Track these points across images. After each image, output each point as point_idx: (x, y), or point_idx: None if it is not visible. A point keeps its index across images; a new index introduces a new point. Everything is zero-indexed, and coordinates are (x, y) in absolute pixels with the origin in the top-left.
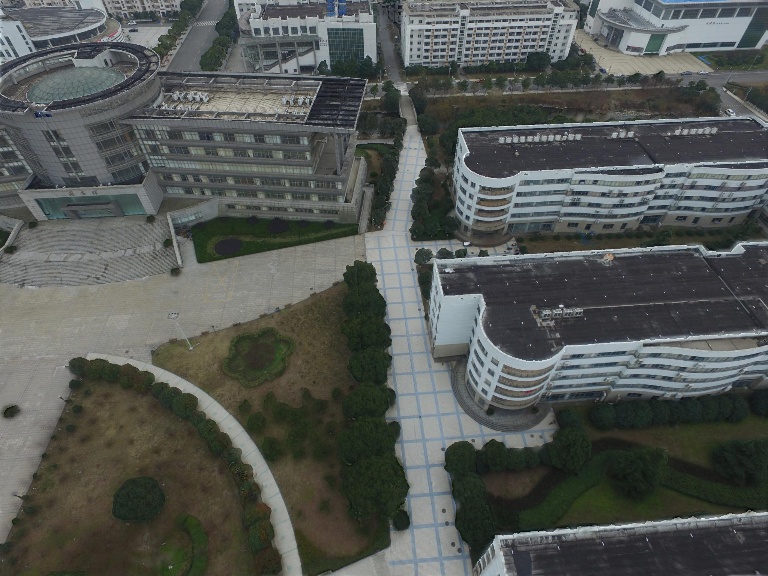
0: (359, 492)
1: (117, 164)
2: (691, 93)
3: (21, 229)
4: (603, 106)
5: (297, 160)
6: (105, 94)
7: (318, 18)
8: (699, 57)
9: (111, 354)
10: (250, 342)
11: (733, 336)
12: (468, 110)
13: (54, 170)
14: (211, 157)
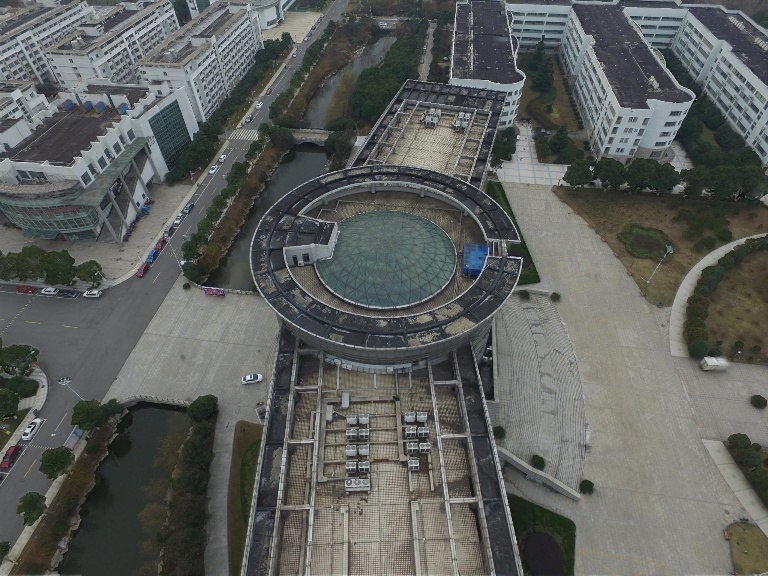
0: (766, 179)
1: None
2: (360, 24)
3: None
4: (350, 55)
5: None
6: (472, 196)
7: (127, 117)
8: (298, 11)
9: (669, 337)
10: None
11: None
12: (352, 95)
13: None
14: None
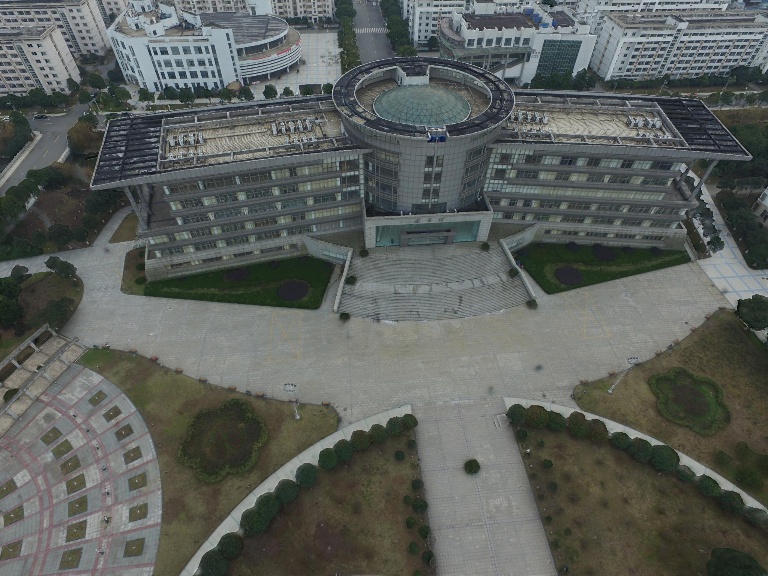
0: None
1: (468, 189)
2: None
3: (352, 257)
4: None
5: (656, 186)
6: (492, 117)
7: None
8: None
9: (529, 398)
10: (669, 384)
11: None
12: None
13: (409, 196)
14: (561, 182)
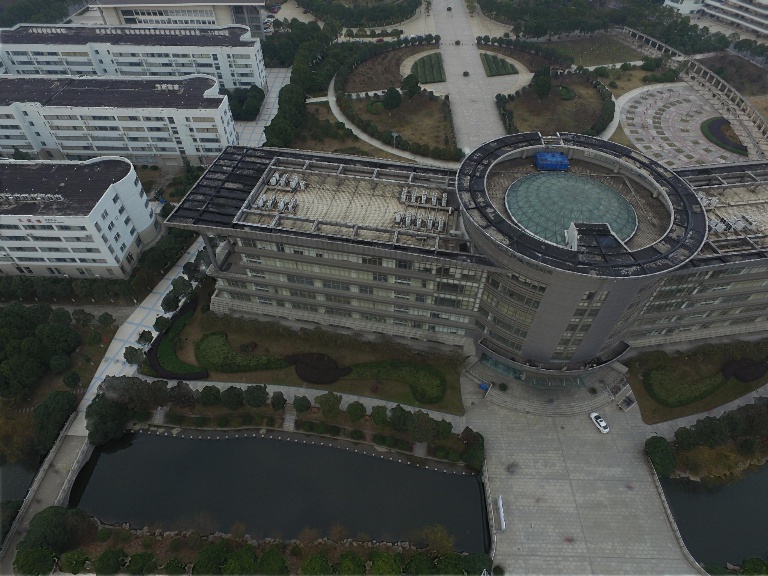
0: None
1: None
2: None
3: None
4: None
5: None
6: (492, 150)
7: None
8: None
9: None
10: None
11: (93, 78)
12: None
13: None
14: None
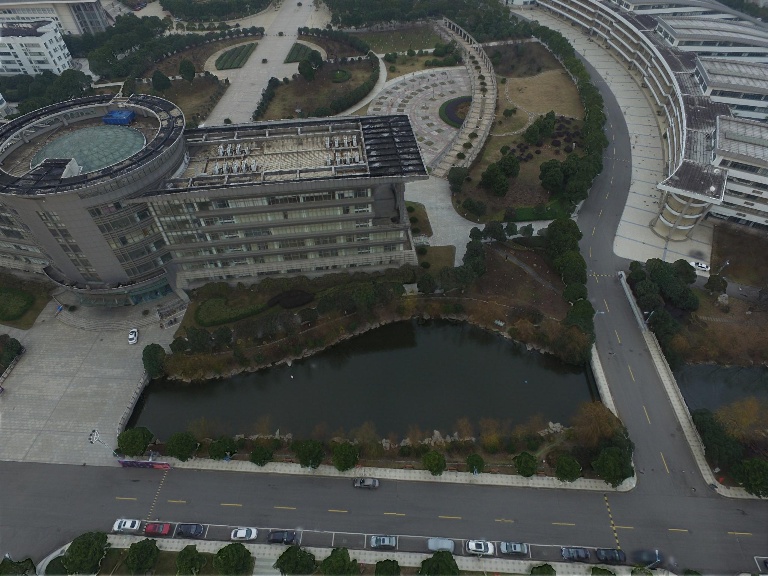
0: None
1: None
2: None
3: None
4: None
5: None
6: (59, 107)
7: None
8: None
9: None
10: None
11: None
12: None
13: None
14: None
